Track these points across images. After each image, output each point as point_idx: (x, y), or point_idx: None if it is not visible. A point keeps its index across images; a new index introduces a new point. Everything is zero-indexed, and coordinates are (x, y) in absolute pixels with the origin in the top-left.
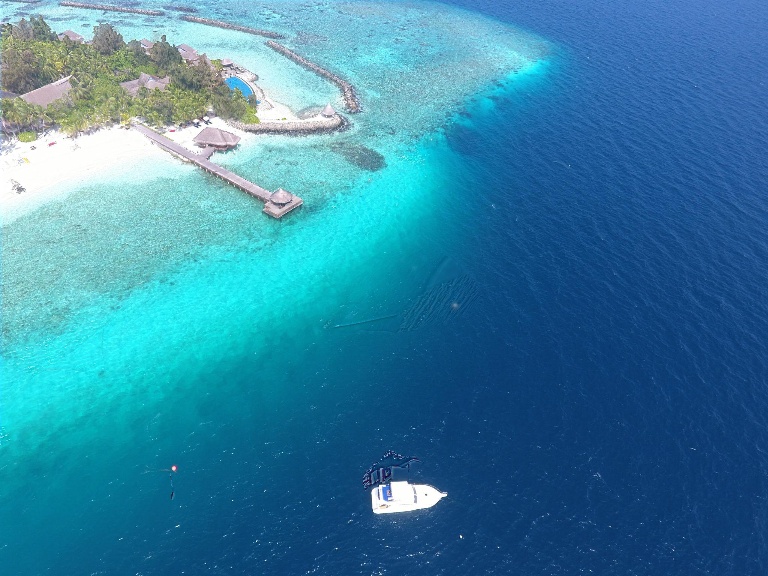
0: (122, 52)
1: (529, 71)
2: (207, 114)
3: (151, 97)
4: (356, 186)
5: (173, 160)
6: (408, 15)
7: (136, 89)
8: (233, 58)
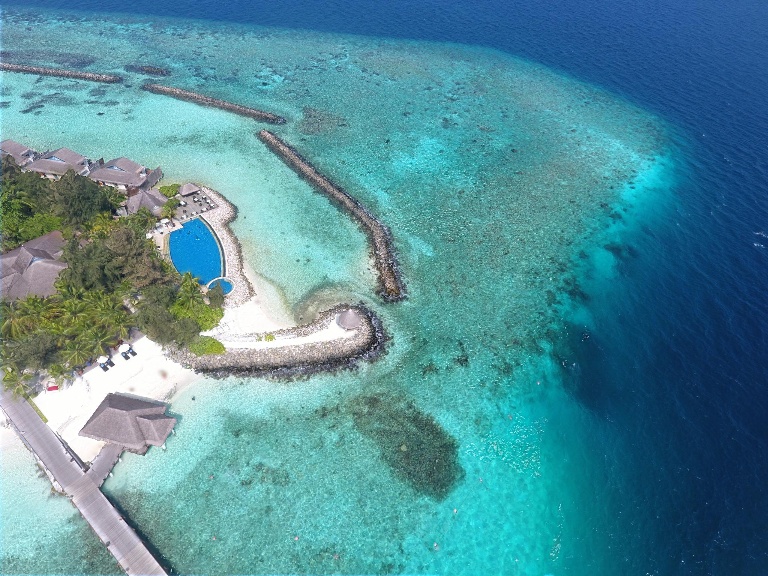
0: (2, 196)
1: (650, 181)
2: (131, 328)
3: (17, 318)
4: (407, 564)
5: (35, 482)
6: (456, 73)
7: (8, 280)
8: (204, 168)
